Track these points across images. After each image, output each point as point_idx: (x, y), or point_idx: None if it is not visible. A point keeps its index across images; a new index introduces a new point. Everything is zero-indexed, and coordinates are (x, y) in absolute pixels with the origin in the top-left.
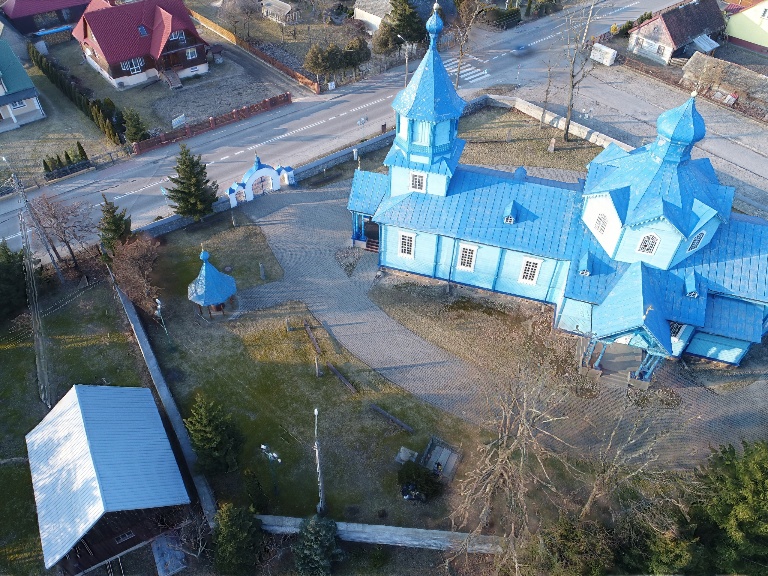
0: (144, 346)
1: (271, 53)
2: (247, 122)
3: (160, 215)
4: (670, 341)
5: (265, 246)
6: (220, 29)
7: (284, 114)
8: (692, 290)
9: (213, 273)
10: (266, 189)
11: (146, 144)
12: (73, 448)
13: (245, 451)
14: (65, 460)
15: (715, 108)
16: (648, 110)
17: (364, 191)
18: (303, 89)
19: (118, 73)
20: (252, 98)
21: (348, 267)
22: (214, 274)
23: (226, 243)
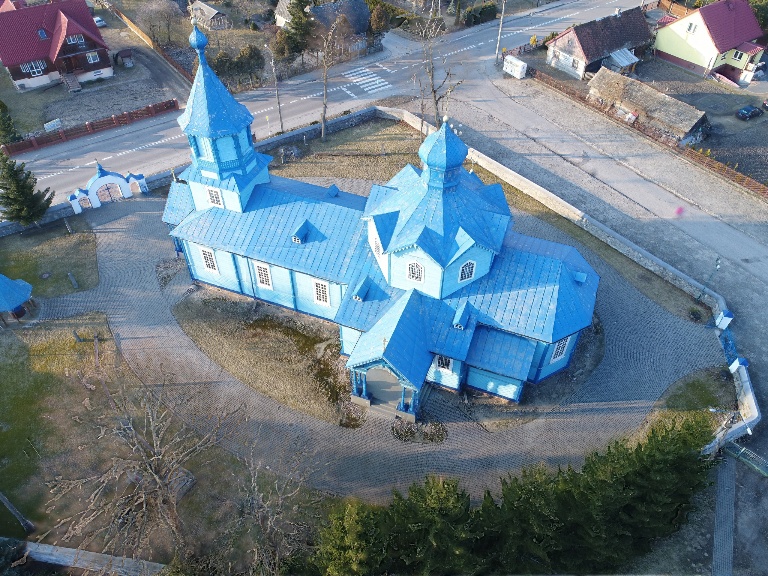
0: None
1: (184, 58)
2: (127, 127)
3: None
4: (425, 374)
5: (92, 254)
6: (141, 33)
7: (167, 120)
8: (456, 322)
9: None
10: (115, 196)
11: (16, 147)
12: None
13: None
14: None
15: (613, 126)
16: (541, 126)
17: (178, 203)
18: None
19: (18, 75)
20: (144, 103)
21: (164, 279)
22: (1, 282)
23: (55, 249)
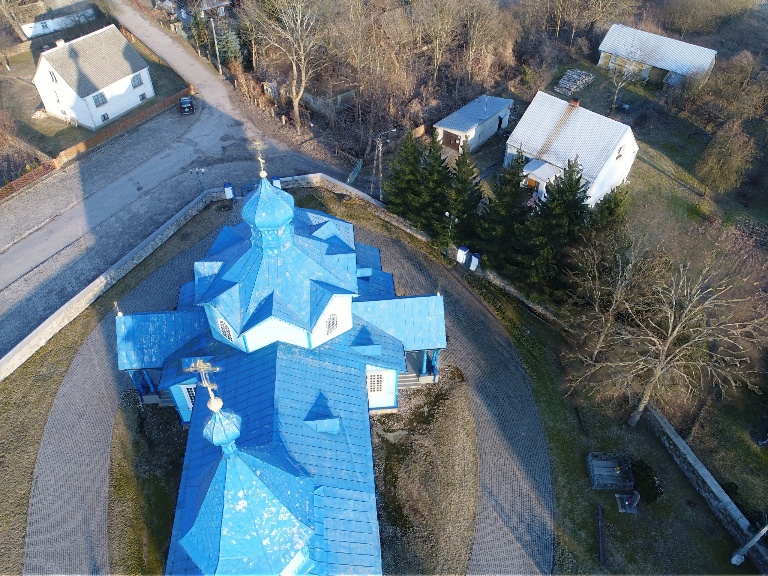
0: None
1: None
2: None
3: None
4: None
5: None
6: None
7: None
8: None
9: None
10: None
11: None
12: None
13: None
14: None
15: None
16: None
17: None
18: None
19: None
20: None
21: None
22: None
23: None
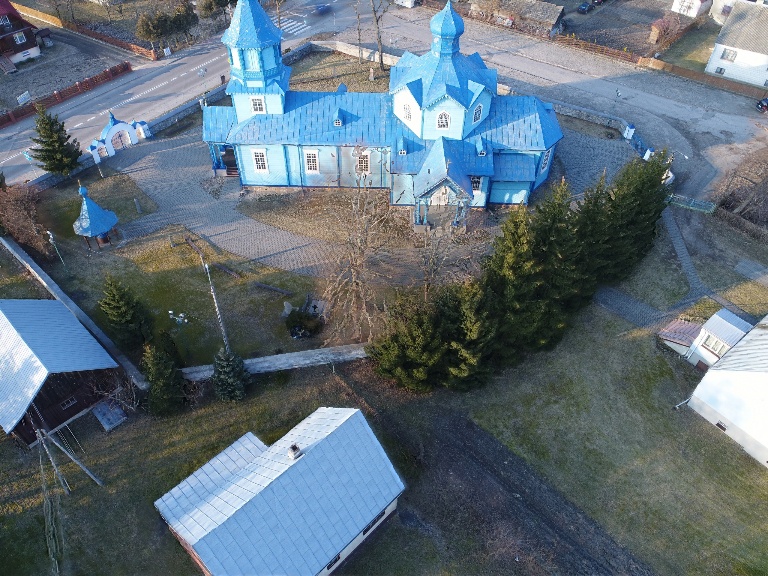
0: (44, 277)
1: (101, 31)
2: (92, 92)
3: (28, 180)
4: (471, 189)
5: (136, 188)
6: (42, 15)
7: (127, 81)
8: (481, 150)
9: (94, 206)
10: (125, 143)
11: None
12: (5, 344)
13: (156, 335)
14: (0, 355)
15: (498, 30)
16: None
17: (214, 123)
18: (140, 58)
19: None
20: (92, 72)
21: (214, 192)
22: (95, 207)
23: (98, 192)
